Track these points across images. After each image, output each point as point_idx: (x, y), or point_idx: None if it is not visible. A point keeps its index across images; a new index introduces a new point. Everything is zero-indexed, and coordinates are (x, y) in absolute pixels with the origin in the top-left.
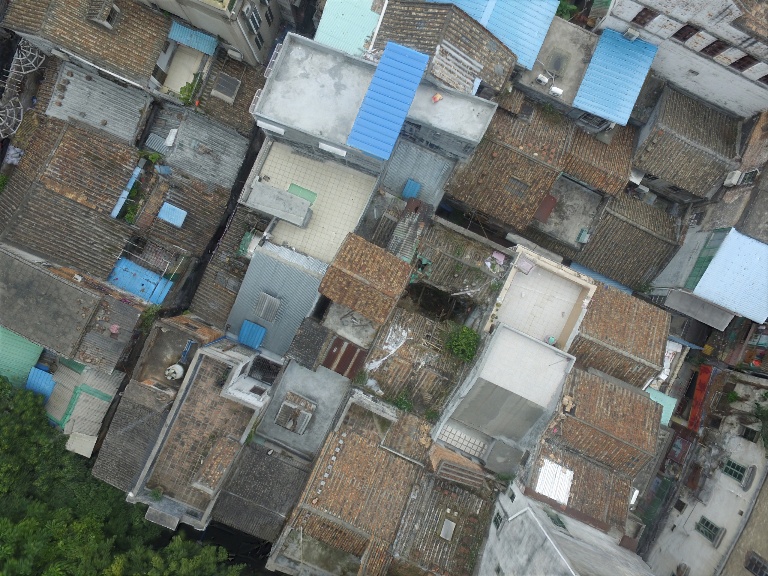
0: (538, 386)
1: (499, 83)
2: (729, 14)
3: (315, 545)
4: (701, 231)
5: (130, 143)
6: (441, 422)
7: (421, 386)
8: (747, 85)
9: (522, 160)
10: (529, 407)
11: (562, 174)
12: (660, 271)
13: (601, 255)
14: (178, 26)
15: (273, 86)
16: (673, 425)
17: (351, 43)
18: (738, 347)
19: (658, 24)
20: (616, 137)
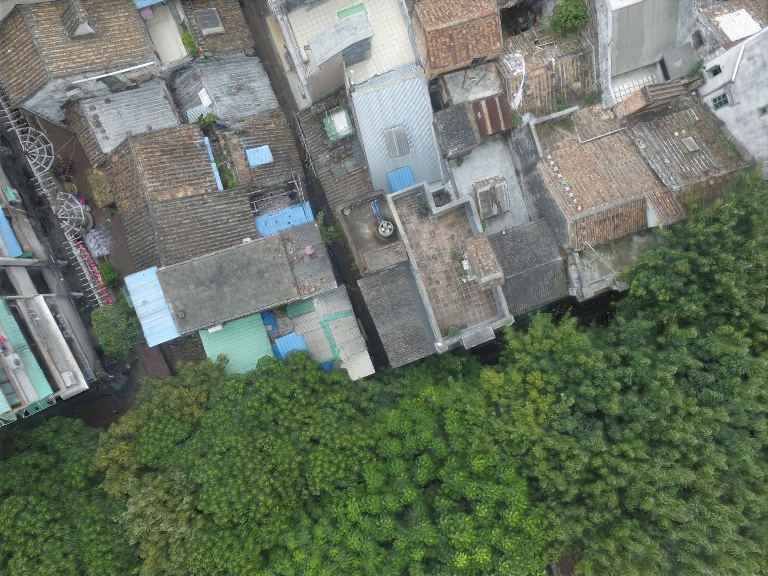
0: None
1: None
2: None
3: None
4: None
5: None
6: (607, 86)
7: (566, 81)
8: None
9: None
10: (665, 2)
11: None
12: None
13: None
14: None
15: None
16: None
17: None
18: None
19: None
20: None
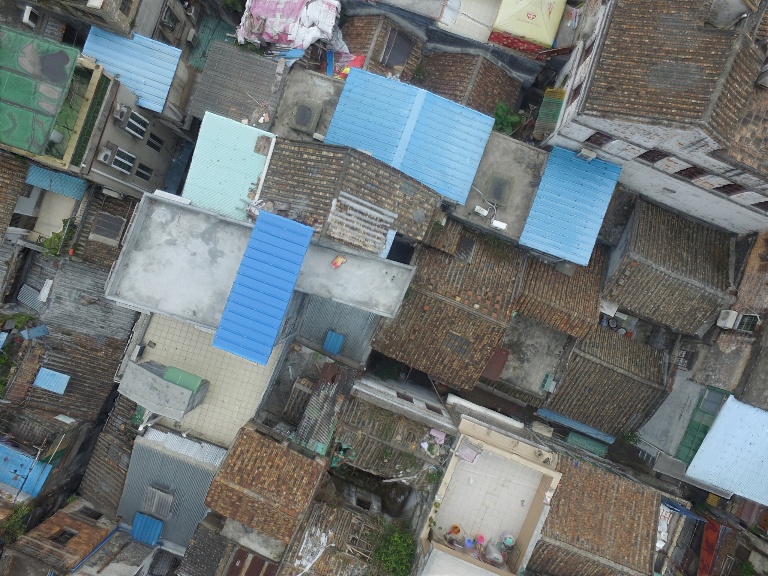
0: None
1: (421, 231)
2: (705, 145)
3: None
4: (692, 380)
5: None
6: None
7: None
8: (737, 208)
9: (460, 313)
10: None
11: (516, 314)
12: (646, 419)
13: (573, 400)
14: (37, 169)
15: (132, 257)
16: None
17: (231, 194)
18: None
19: (617, 147)
20: None
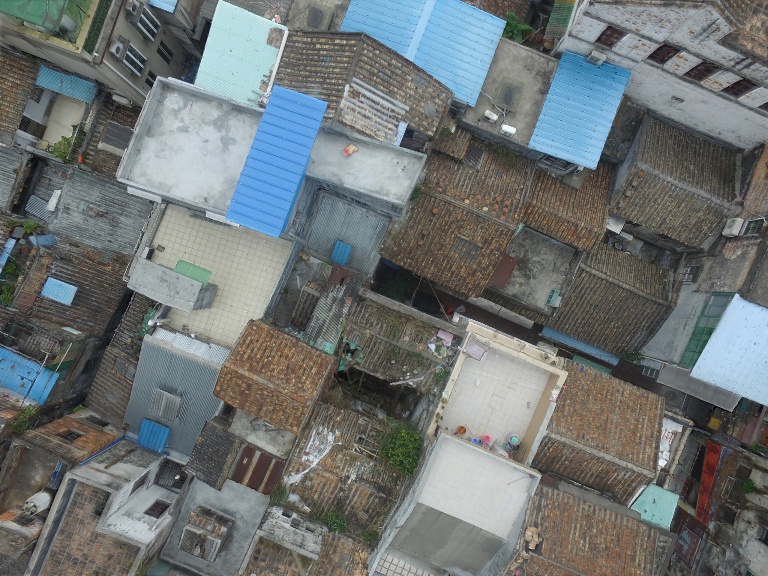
0: (494, 511)
1: (432, 126)
2: (716, 30)
3: None
4: (697, 291)
5: (4, 209)
6: (377, 553)
7: (353, 503)
8: (745, 113)
9: (469, 216)
10: (485, 537)
11: (524, 226)
12: (651, 336)
13: (578, 319)
14: (48, 70)
15: (144, 144)
16: (678, 509)
17: (243, 85)
18: (751, 421)
19: (628, 45)
20: (588, 178)
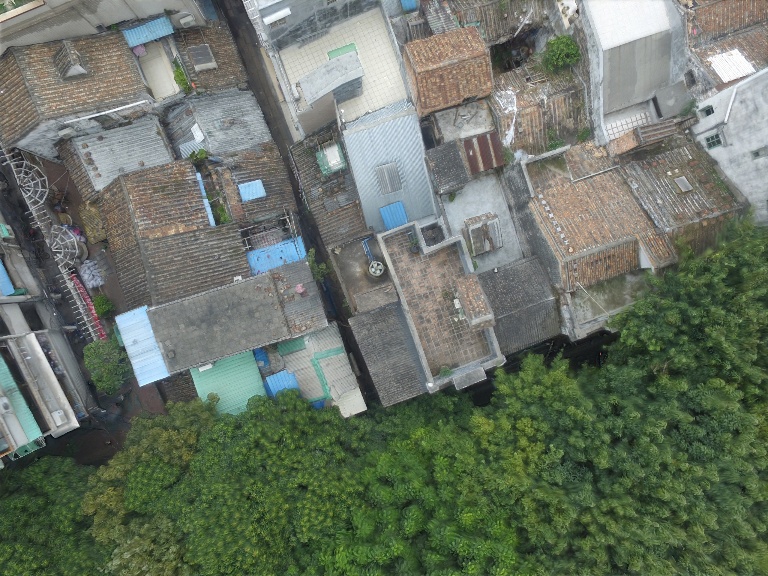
0: (650, 17)
1: None
2: None
3: (595, 297)
4: None
5: None
6: (600, 124)
7: (558, 118)
8: None
9: None
10: (657, 41)
11: None
12: None
13: None
14: (129, 32)
15: None
16: None
17: None
18: None
19: None
20: None
